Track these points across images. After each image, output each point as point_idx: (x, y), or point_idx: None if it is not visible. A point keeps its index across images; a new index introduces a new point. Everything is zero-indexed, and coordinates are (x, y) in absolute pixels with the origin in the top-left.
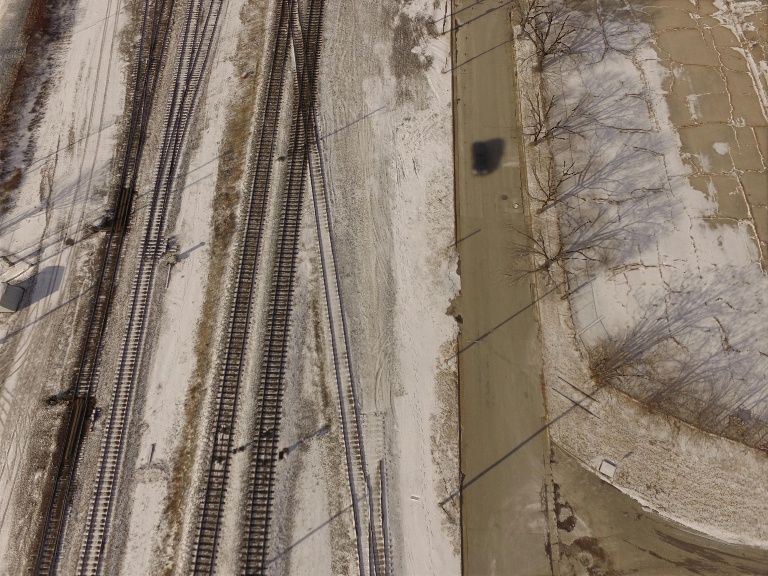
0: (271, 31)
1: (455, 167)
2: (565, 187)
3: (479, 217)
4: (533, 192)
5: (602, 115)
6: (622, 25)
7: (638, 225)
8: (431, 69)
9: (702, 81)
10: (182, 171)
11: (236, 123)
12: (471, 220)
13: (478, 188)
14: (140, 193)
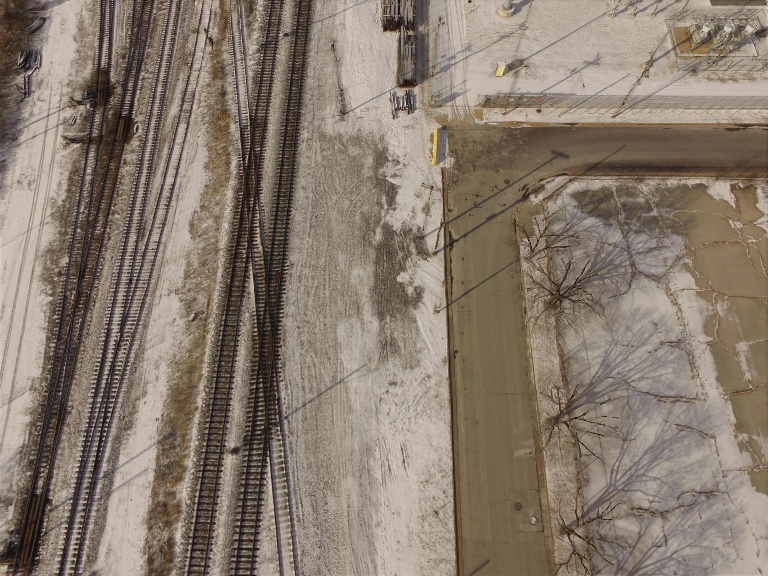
0: (226, 253)
1: (454, 459)
2: (594, 489)
3: (487, 540)
4: (554, 498)
5: (634, 374)
6: (650, 238)
7: (690, 551)
8: (421, 306)
9: (753, 321)
10: (110, 466)
11: (180, 390)
12: (477, 545)
13: (484, 492)
14: (55, 503)
